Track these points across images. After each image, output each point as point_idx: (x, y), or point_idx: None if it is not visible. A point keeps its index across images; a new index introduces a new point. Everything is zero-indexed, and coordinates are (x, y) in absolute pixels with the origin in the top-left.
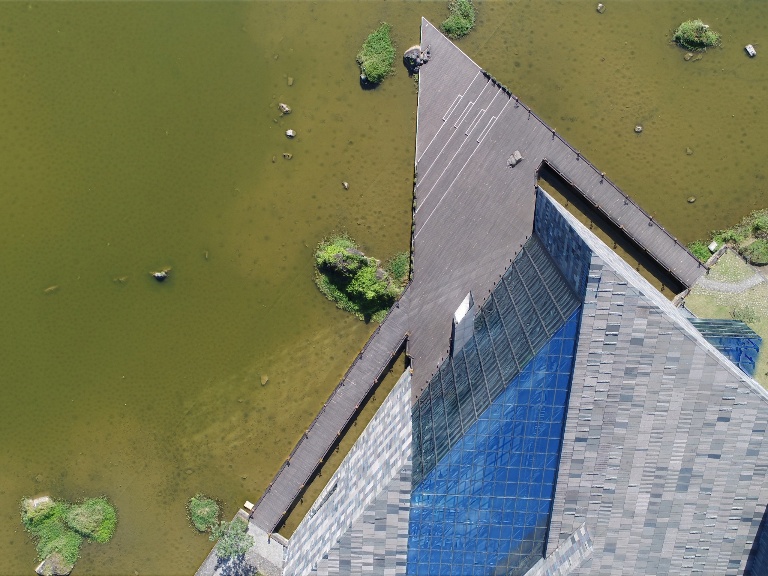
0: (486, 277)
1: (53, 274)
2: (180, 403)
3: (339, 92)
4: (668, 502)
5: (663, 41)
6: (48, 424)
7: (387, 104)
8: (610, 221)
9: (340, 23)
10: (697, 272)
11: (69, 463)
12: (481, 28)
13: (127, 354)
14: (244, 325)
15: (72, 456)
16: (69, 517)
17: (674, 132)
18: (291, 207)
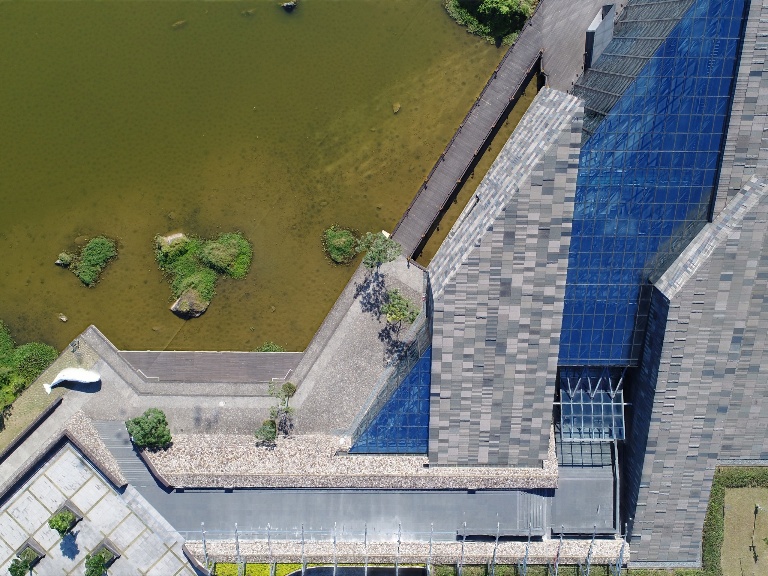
0: None
1: (180, 9)
2: (312, 134)
3: None
4: None
5: None
6: (179, 160)
7: None
8: None
9: None
10: None
11: (202, 199)
12: None
13: (257, 87)
14: (374, 54)
15: (205, 192)
16: (204, 252)
17: None
18: None
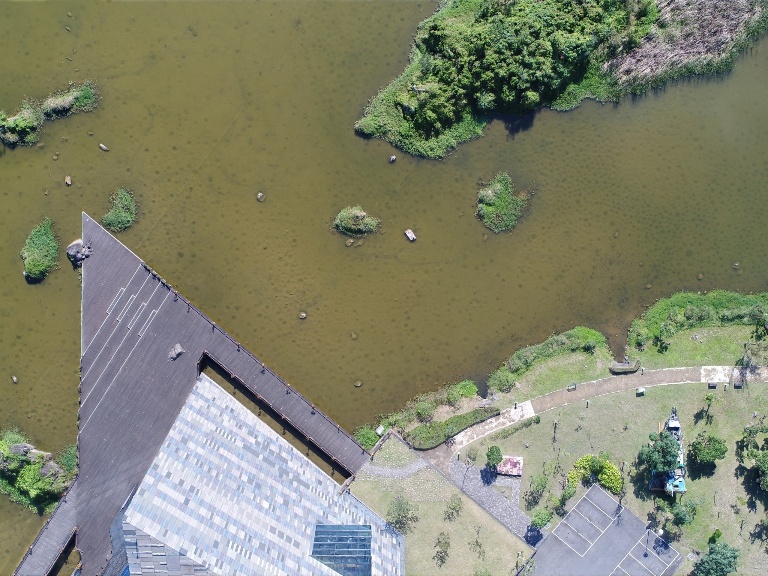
0: None
1: None
2: None
3: (5, 287)
4: None
5: (324, 228)
6: None
7: (53, 298)
8: (273, 410)
9: (3, 219)
10: (361, 458)
11: None
12: (143, 220)
13: None
14: None
15: None
16: None
17: (338, 317)
18: None
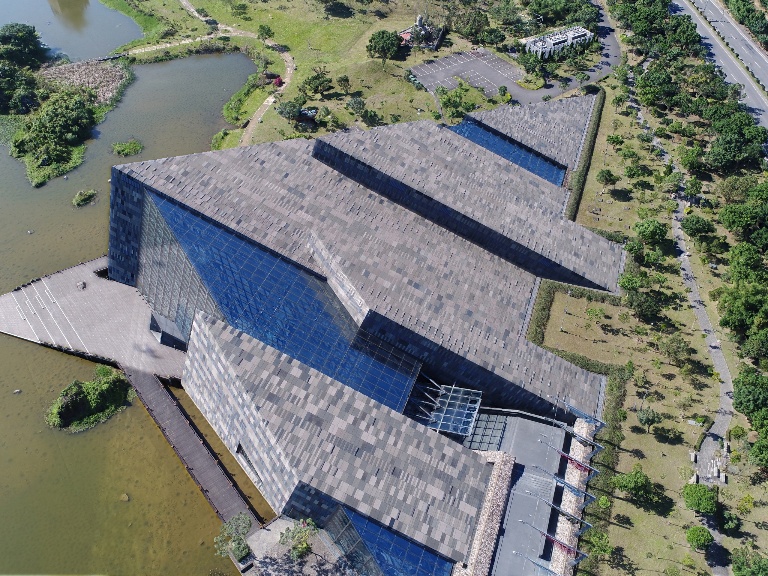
0: (147, 319)
1: None
2: None
3: None
4: (310, 205)
5: (75, 211)
6: None
7: None
8: None
9: None
10: None
11: None
12: None
13: None
14: (67, 501)
15: None
16: None
17: None
18: (2, 435)
